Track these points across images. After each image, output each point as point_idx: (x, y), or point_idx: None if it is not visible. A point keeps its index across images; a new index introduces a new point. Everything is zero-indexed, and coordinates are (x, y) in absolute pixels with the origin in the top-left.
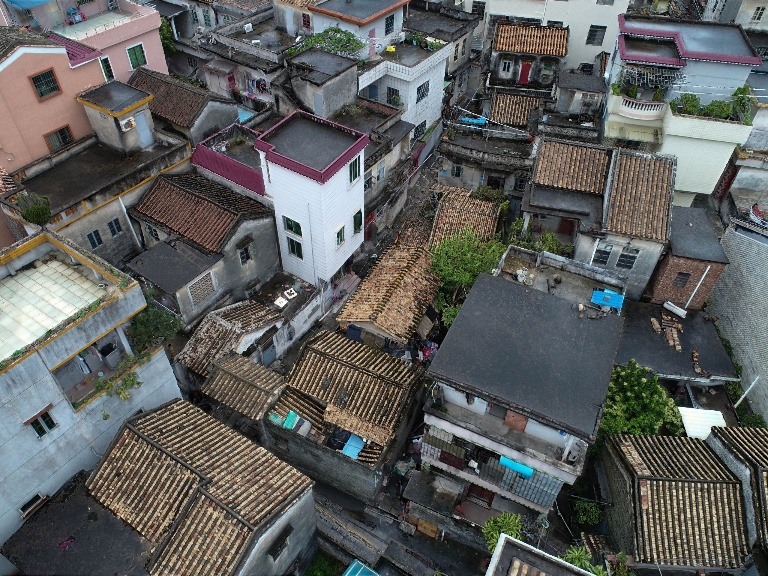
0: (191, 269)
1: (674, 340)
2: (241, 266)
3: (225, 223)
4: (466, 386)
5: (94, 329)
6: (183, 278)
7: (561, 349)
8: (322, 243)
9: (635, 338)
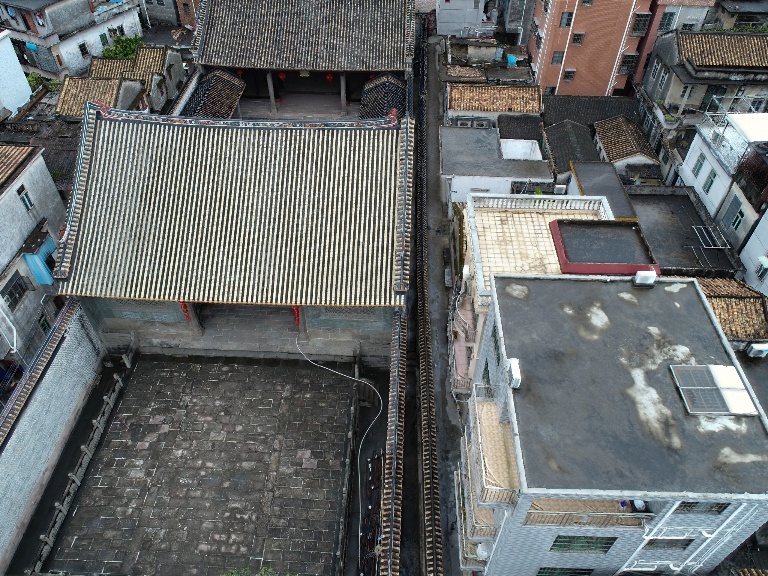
0: None
1: None
2: None
3: None
4: None
5: None
6: None
7: None
8: None
9: (158, 36)
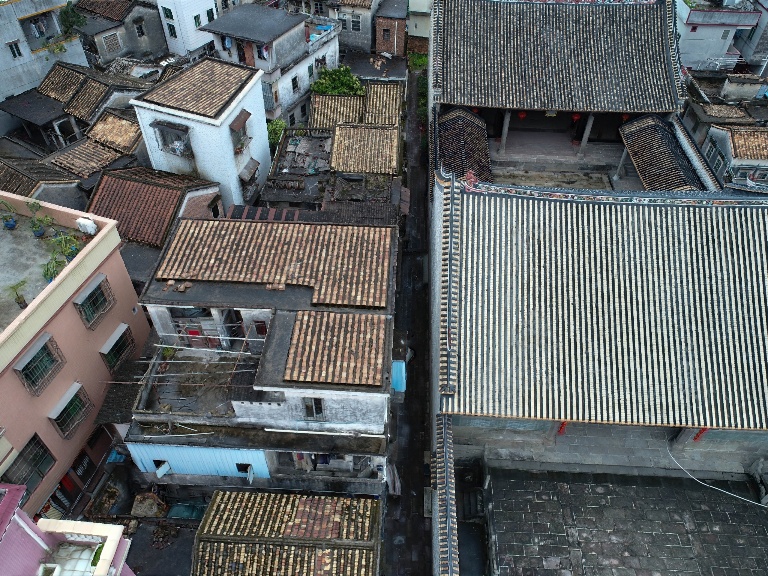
0: (104, 26)
1: (378, 65)
2: (138, 38)
3: (126, 6)
4: (216, 30)
5: (39, 5)
6: (98, 29)
7: (270, 22)
8: (184, 20)
9: (357, 65)
